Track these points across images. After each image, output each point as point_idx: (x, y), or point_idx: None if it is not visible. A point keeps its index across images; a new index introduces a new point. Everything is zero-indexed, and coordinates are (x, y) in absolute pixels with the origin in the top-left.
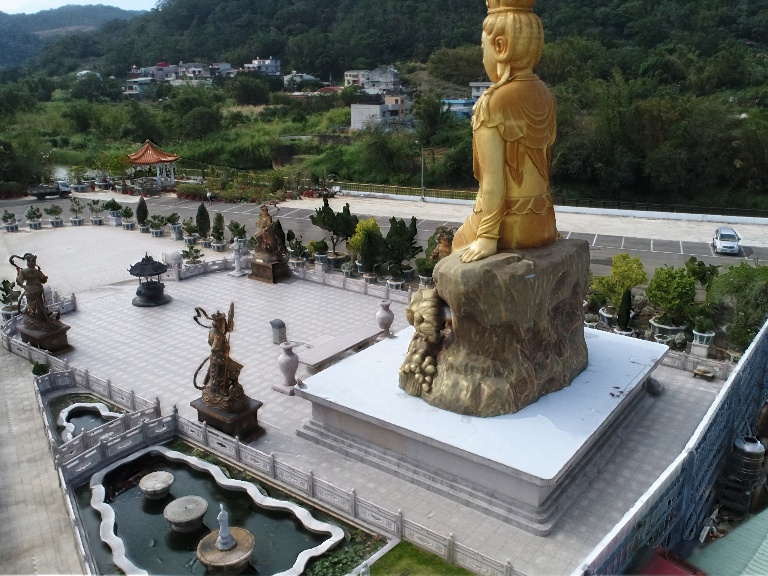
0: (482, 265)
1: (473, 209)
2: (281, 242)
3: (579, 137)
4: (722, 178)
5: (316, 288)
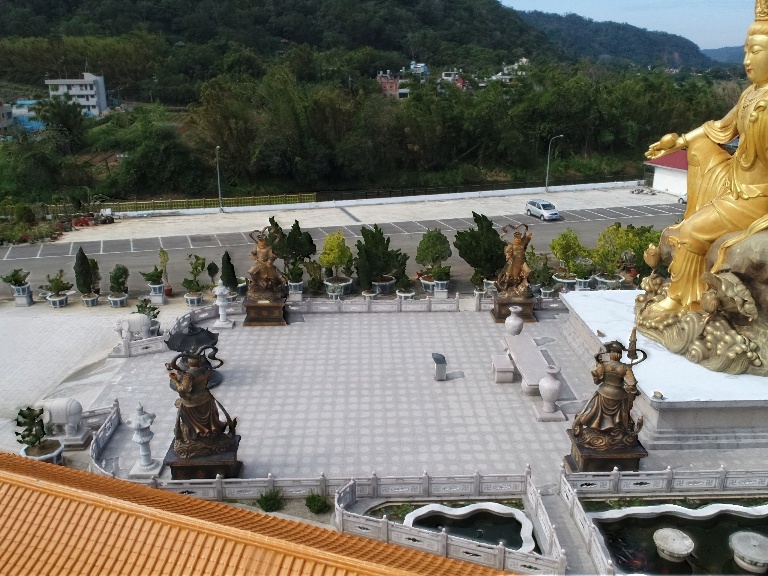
0: None
1: (738, 196)
2: (282, 275)
3: (271, 133)
4: (399, 161)
5: (341, 318)
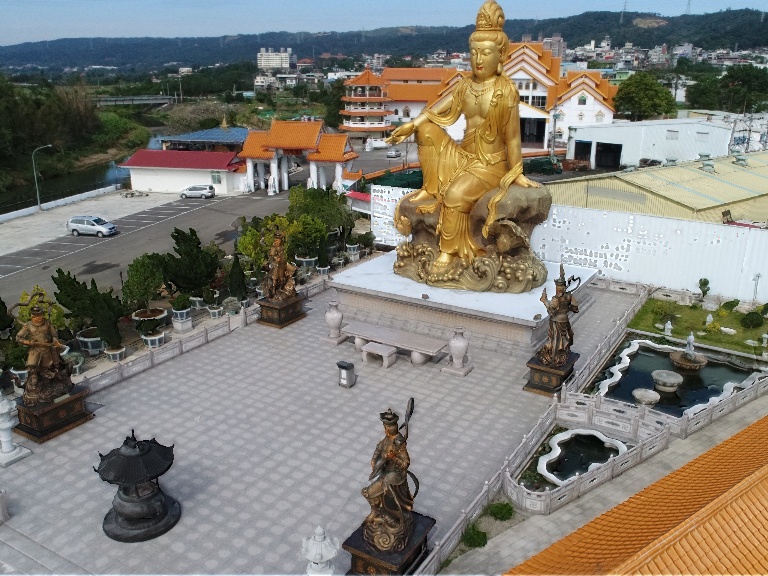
0: None
1: (488, 163)
2: None
3: None
4: None
5: (137, 384)
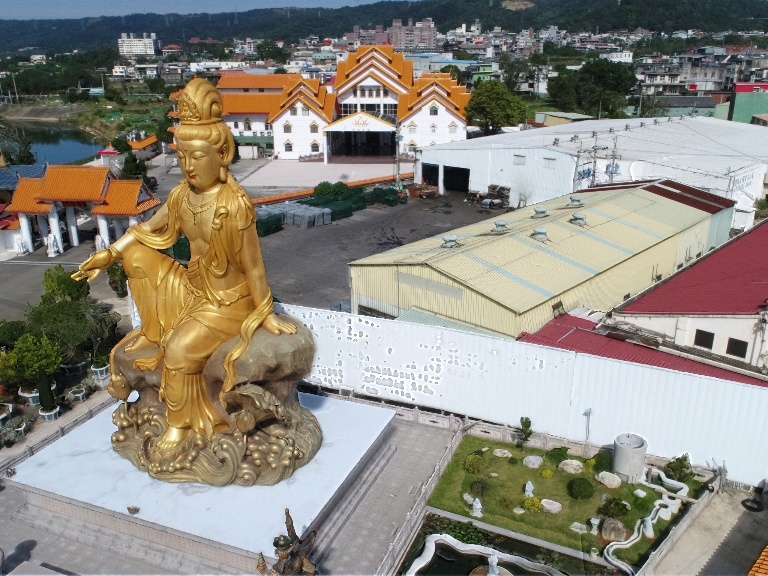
0: None
1: (220, 304)
2: None
3: None
4: None
5: None
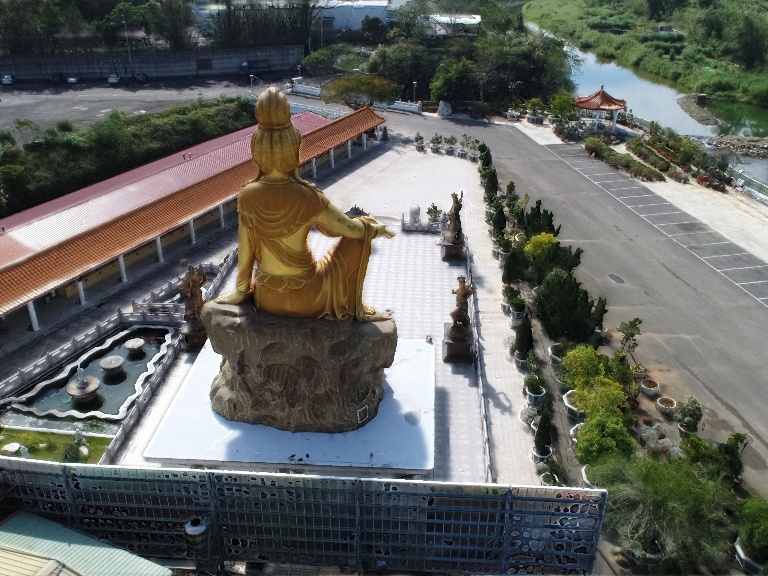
0: (210, 307)
1: None
2: (460, 229)
3: None
4: None
5: None
